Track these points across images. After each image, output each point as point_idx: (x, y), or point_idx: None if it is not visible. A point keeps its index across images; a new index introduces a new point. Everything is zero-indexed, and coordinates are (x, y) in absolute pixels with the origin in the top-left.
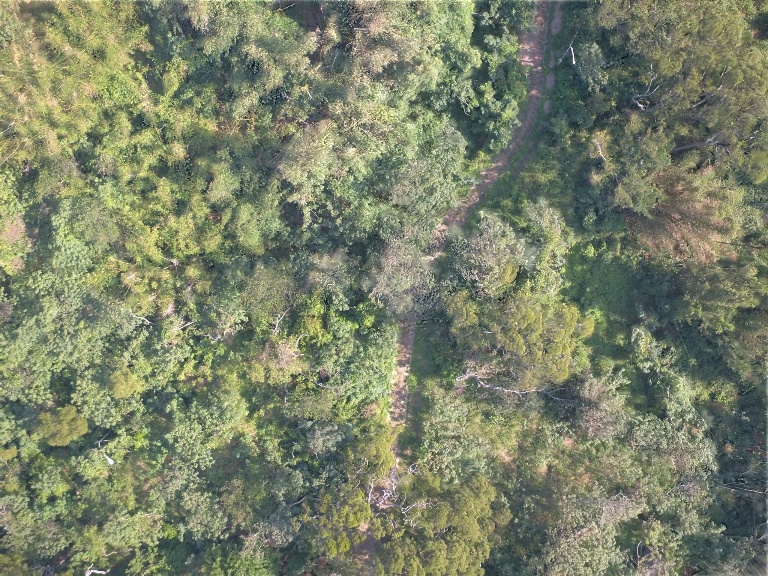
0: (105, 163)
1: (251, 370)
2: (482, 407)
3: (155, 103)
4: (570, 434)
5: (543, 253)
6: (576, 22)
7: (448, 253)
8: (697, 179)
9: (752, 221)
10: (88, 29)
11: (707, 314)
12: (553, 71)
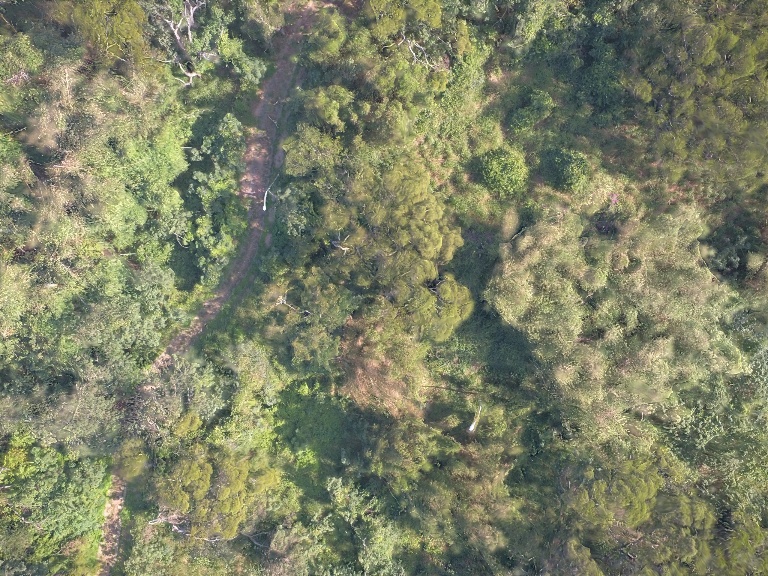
0: None
1: None
2: (189, 546)
3: None
4: None
5: (236, 398)
6: None
7: None
8: (376, 335)
9: (458, 369)
10: None
11: (387, 473)
12: None
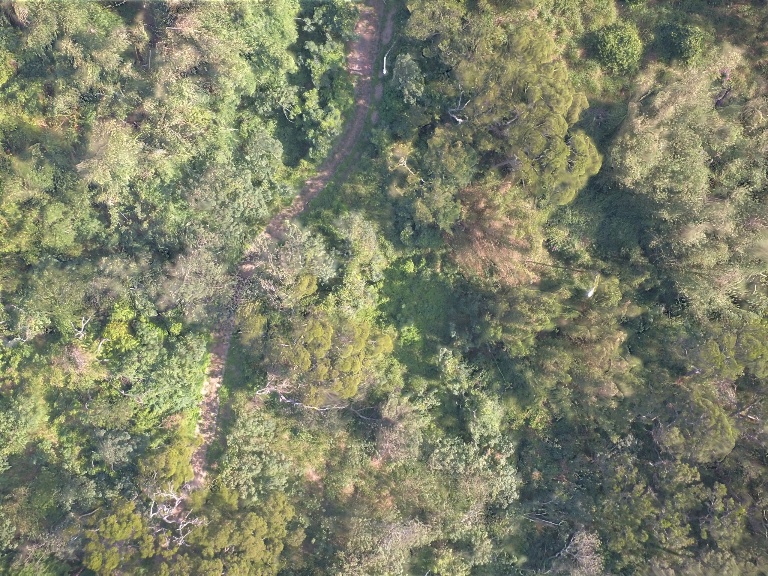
0: None
1: (51, 374)
2: (291, 423)
3: None
4: (377, 455)
5: (350, 266)
6: (403, 33)
7: None
8: (500, 197)
9: (570, 243)
10: None
11: (507, 336)
12: (381, 81)
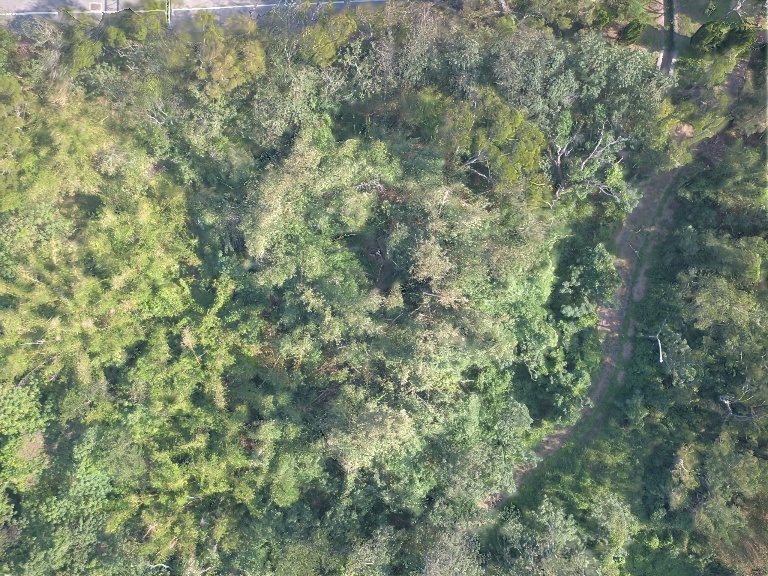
0: (137, 391)
1: None
2: None
3: (197, 321)
4: None
5: (607, 558)
6: (662, 295)
7: (498, 521)
8: None
9: None
10: (134, 235)
11: None
12: (631, 341)
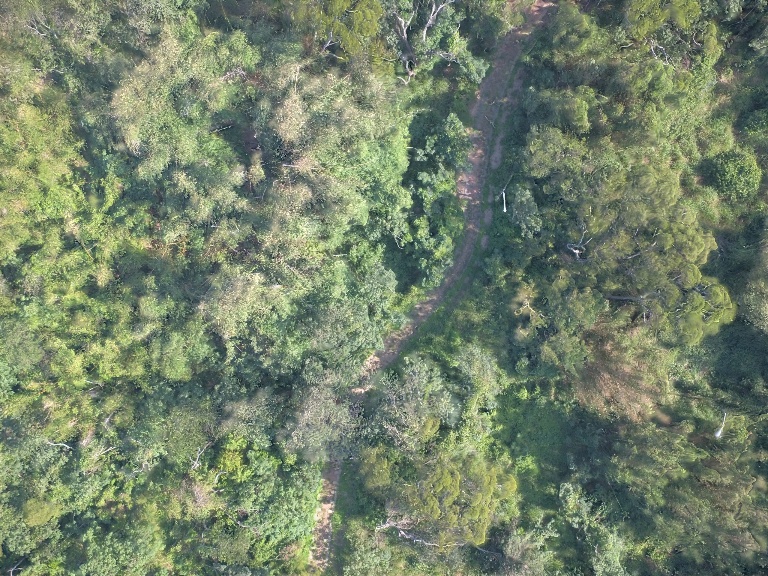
0: (31, 284)
1: (168, 505)
2: (406, 551)
3: (88, 220)
4: None
5: (469, 402)
6: (515, 159)
7: (379, 387)
8: (626, 340)
9: None
10: (24, 142)
11: (634, 479)
12: (491, 206)
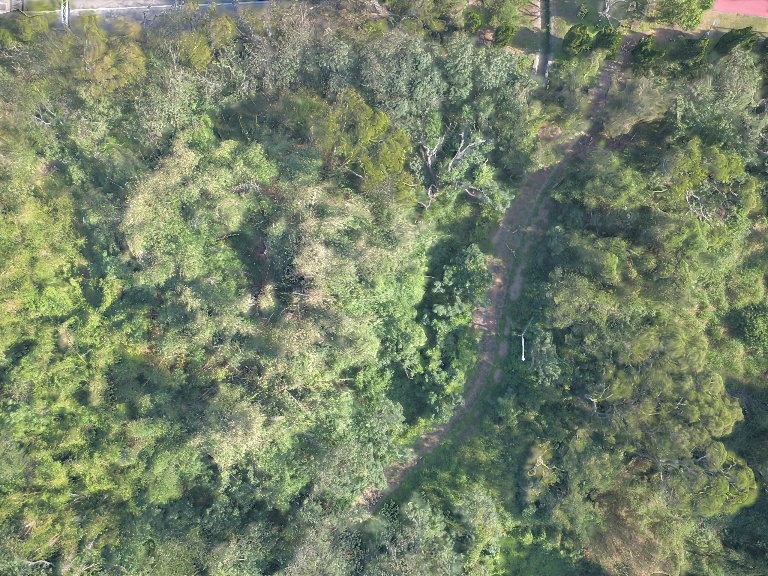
0: (19, 390)
1: None
2: None
3: (84, 320)
4: None
5: (473, 554)
6: (535, 294)
7: (378, 517)
8: (643, 507)
9: (703, 534)
10: (21, 235)
11: None
12: (507, 339)
